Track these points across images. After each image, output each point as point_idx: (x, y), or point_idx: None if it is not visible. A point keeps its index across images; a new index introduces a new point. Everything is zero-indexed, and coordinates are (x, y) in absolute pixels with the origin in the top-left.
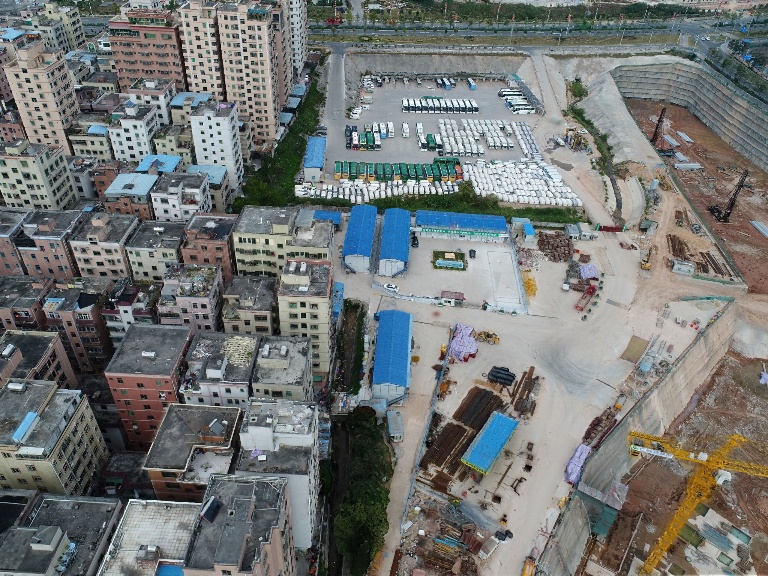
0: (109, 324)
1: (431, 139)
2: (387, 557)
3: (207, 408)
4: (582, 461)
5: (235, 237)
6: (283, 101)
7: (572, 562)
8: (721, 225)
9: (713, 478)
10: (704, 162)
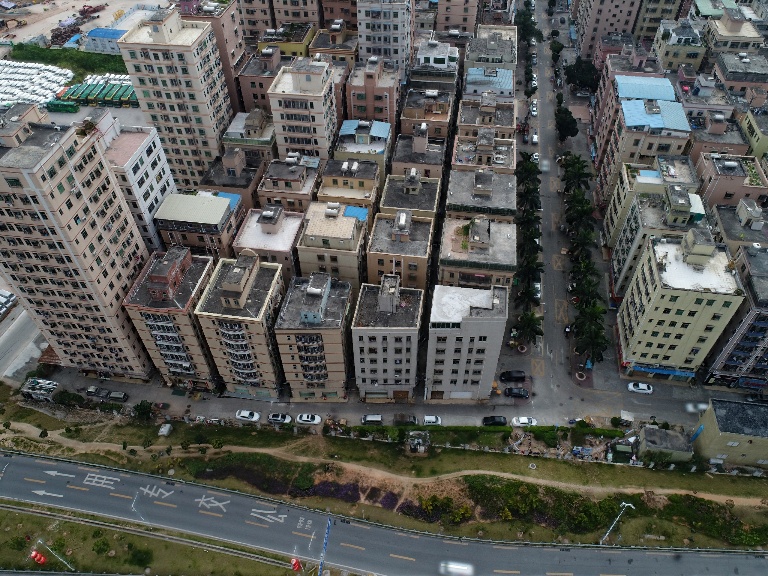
0: None
1: None
2: None
3: None
4: None
5: None
6: None
7: None
8: None
9: None
10: None
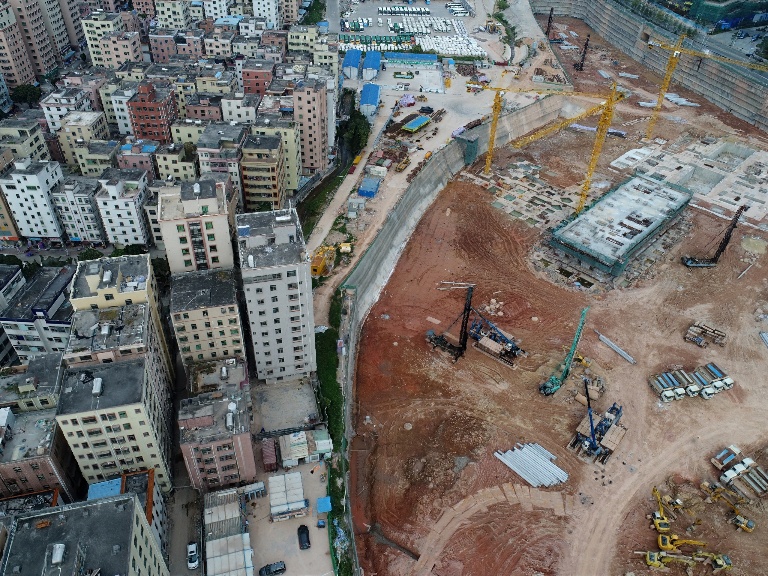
0: None
1: (396, 25)
2: (367, 154)
3: None
4: (460, 131)
5: (289, 35)
6: (299, 2)
7: (453, 169)
8: (578, 72)
9: (498, 95)
10: (581, 45)
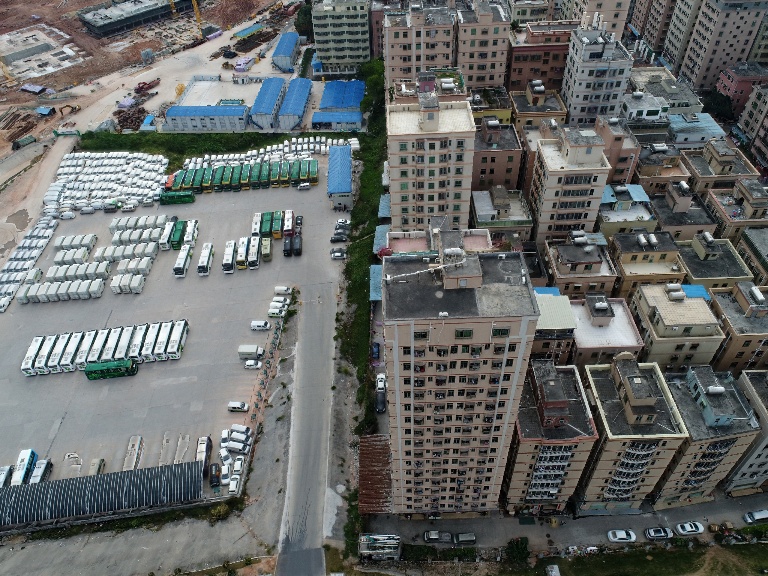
0: None
1: (178, 227)
2: None
3: None
4: None
5: None
6: None
7: None
8: None
9: None
10: None
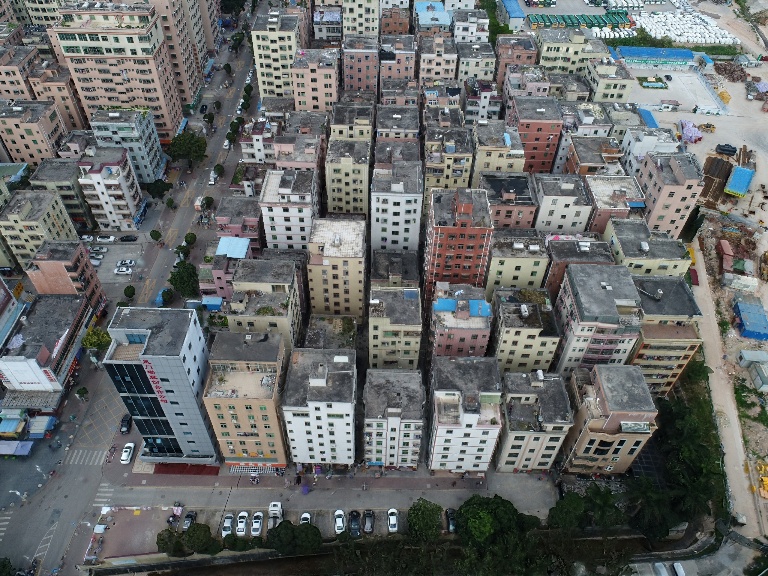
0: (469, 109)
1: None
2: (694, 240)
3: (594, 138)
4: None
5: (545, 47)
6: None
7: None
8: None
9: None
10: None
